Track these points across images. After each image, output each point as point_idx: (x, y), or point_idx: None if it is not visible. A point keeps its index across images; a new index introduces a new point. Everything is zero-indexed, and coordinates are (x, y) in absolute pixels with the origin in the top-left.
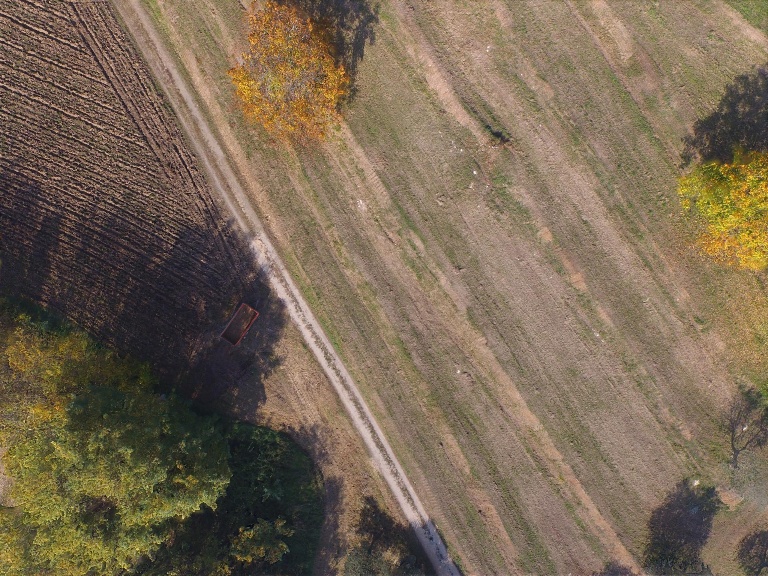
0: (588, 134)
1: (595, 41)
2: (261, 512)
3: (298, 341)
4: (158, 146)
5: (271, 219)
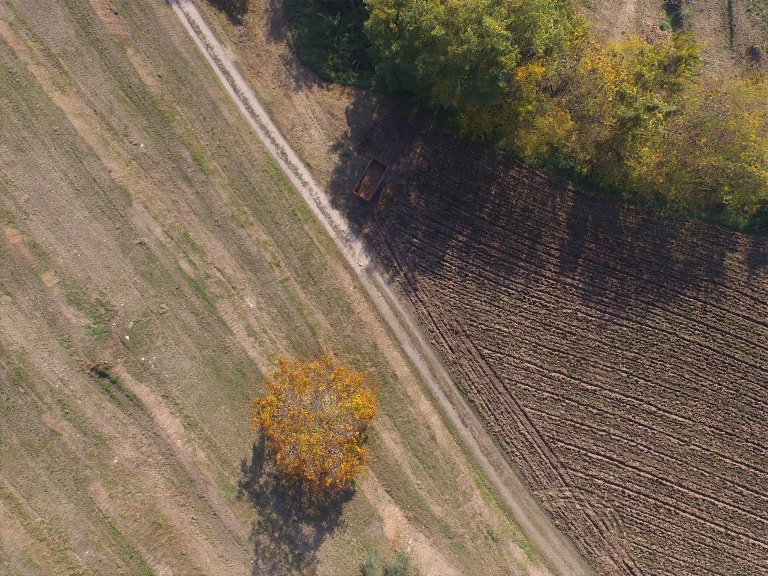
0: (5, 380)
1: (1, 473)
2: (342, 3)
3: (316, 169)
4: (469, 350)
5: (350, 286)
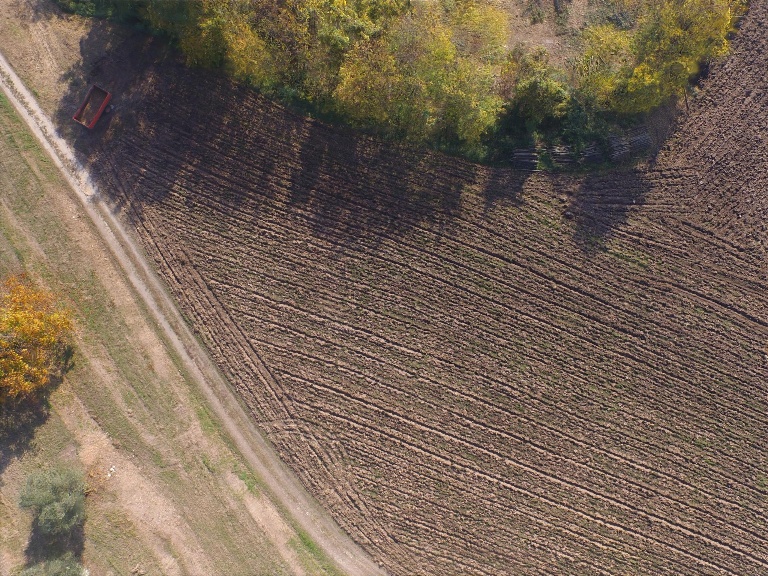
0: None
1: None
2: None
3: (43, 98)
4: (195, 281)
5: (72, 215)
